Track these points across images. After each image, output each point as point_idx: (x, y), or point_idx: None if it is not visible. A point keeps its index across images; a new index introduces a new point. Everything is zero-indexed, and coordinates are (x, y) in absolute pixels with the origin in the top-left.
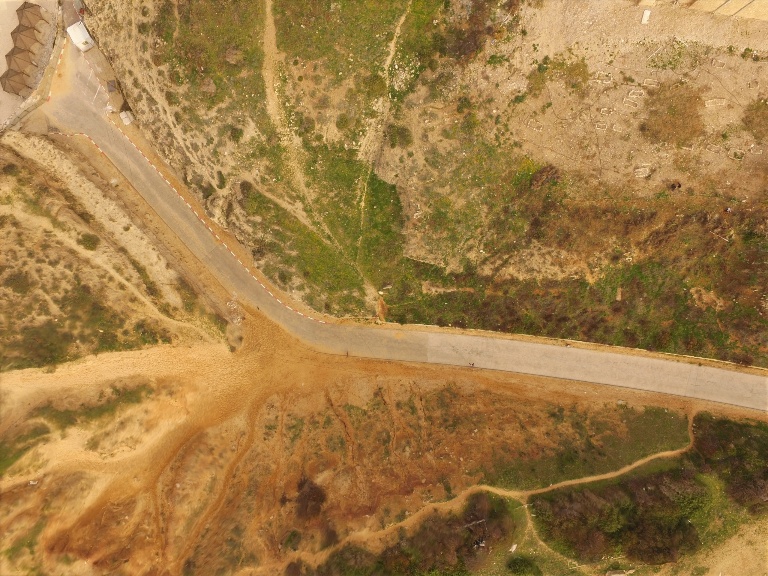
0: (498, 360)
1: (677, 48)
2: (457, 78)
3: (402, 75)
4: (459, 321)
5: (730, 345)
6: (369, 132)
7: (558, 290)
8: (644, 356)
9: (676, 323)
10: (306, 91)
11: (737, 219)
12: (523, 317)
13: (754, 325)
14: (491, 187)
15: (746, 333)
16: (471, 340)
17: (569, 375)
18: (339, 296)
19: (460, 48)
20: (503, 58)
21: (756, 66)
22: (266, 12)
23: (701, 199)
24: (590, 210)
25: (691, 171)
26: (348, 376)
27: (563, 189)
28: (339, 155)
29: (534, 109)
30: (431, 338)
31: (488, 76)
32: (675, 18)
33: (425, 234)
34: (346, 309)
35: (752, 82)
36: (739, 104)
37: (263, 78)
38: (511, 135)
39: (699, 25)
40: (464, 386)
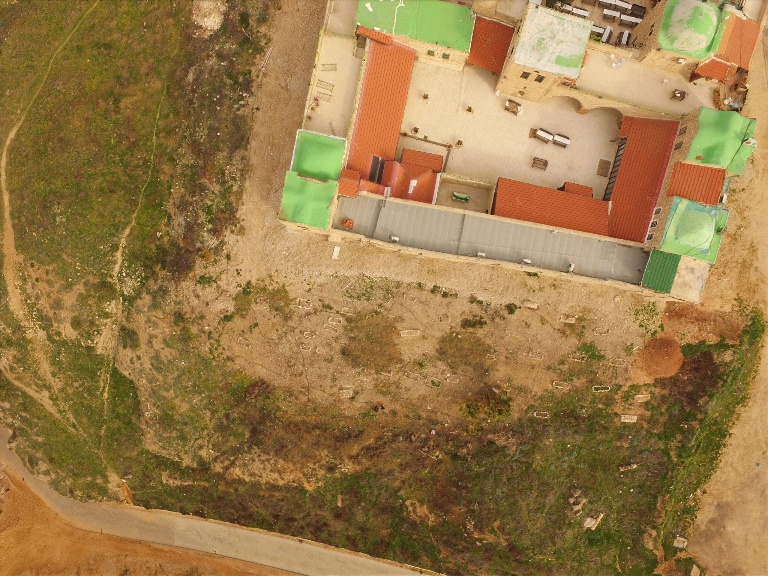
0: (238, 549)
1: (368, 282)
2: (171, 294)
3: (129, 282)
4: (199, 511)
5: (443, 559)
6: (105, 330)
7: (281, 494)
8: (370, 558)
9: (393, 533)
10: (43, 292)
11: (443, 440)
12: (254, 514)
13: (460, 545)
14: (211, 395)
15: (454, 551)
16: (214, 527)
17: (302, 570)
18: (83, 482)
19: (177, 264)
20: (211, 279)
21: (446, 302)
22: (5, 216)
23: (405, 420)
24: (302, 424)
25: (392, 395)
26: (100, 554)
27: (276, 402)
28: (80, 350)
29: (242, 328)
30: (178, 522)
31: (199, 295)
32: (363, 255)
33: (156, 432)
34: (89, 496)
35: (443, 316)
36: (433, 336)
37: (4, 277)
38: (223, 350)
39: (387, 262)
40: (205, 573)
